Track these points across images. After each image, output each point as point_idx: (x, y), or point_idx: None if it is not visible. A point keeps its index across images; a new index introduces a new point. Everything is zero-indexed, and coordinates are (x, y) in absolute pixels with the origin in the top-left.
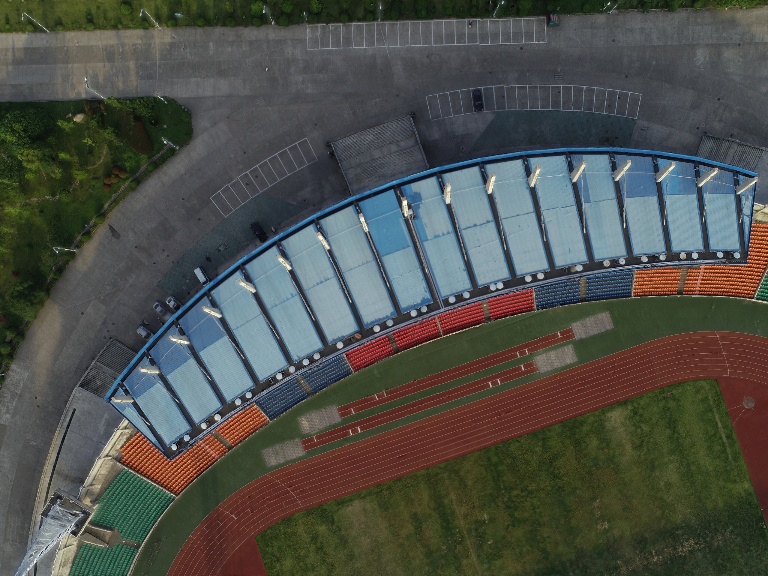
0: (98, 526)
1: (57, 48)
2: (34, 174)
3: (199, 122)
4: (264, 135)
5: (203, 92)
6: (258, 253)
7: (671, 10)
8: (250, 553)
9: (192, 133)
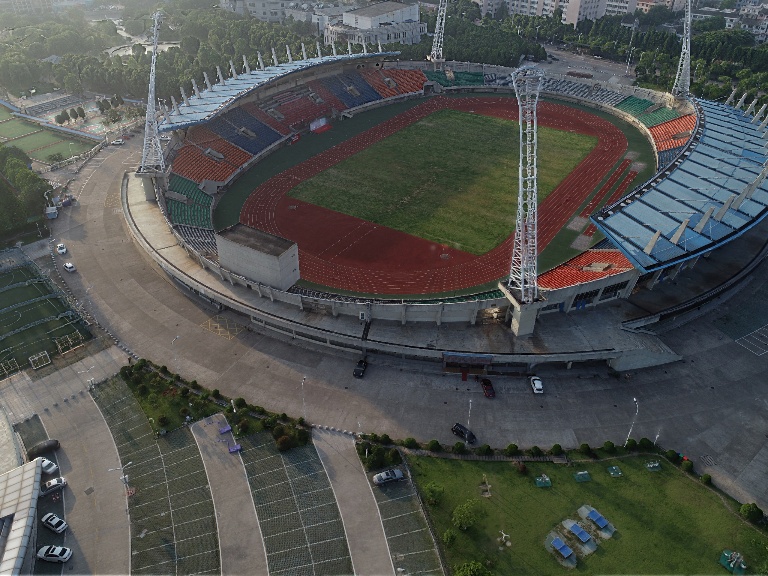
0: None
1: None
2: None
3: None
4: None
5: None
6: None
7: None
8: None
9: None
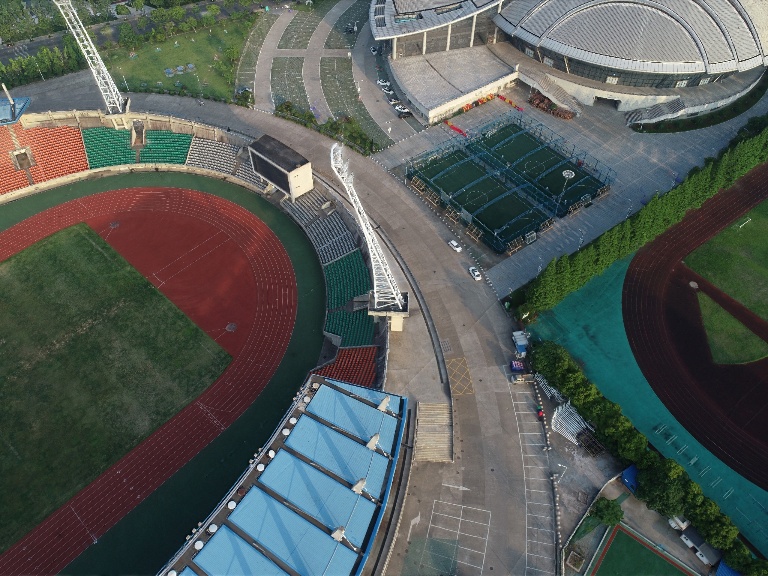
0: None
1: None
2: None
3: None
4: None
5: None
6: None
7: (8, 89)
8: None
9: None
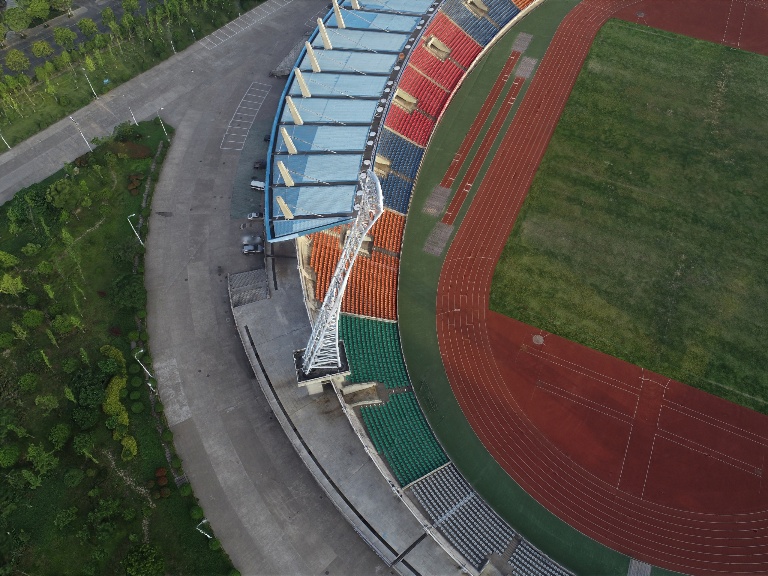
0: None
1: (25, 152)
2: (67, 212)
3: (172, 120)
4: (224, 98)
5: (160, 106)
6: (290, 84)
7: None
8: (500, 324)
9: None
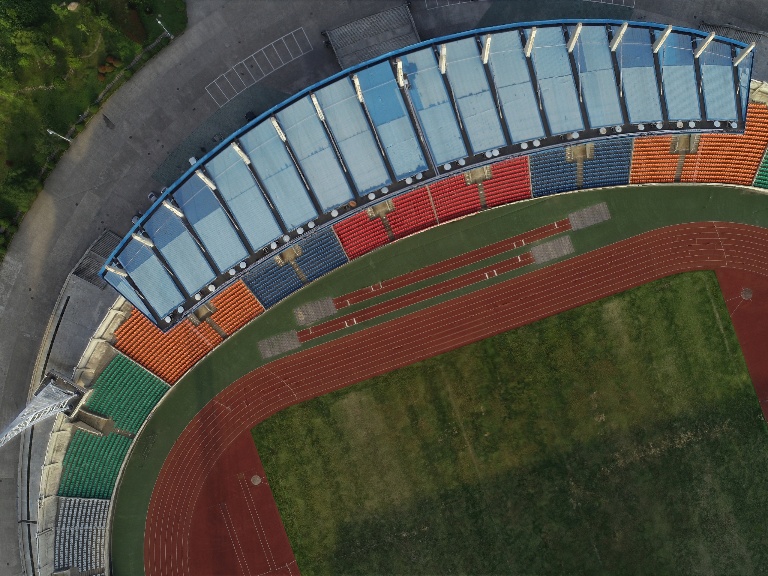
0: (92, 413)
1: None
2: (28, 61)
3: (194, 11)
4: (259, 24)
5: None
6: (252, 126)
7: None
8: (245, 446)
9: (187, 22)
